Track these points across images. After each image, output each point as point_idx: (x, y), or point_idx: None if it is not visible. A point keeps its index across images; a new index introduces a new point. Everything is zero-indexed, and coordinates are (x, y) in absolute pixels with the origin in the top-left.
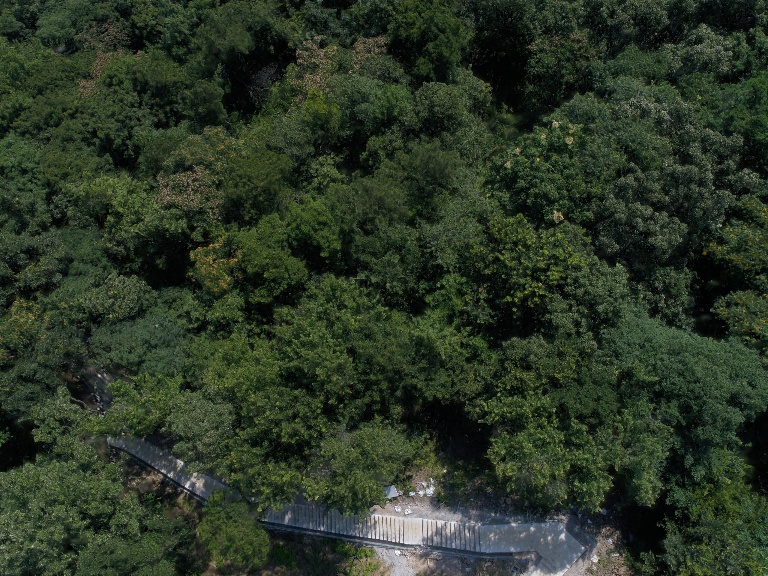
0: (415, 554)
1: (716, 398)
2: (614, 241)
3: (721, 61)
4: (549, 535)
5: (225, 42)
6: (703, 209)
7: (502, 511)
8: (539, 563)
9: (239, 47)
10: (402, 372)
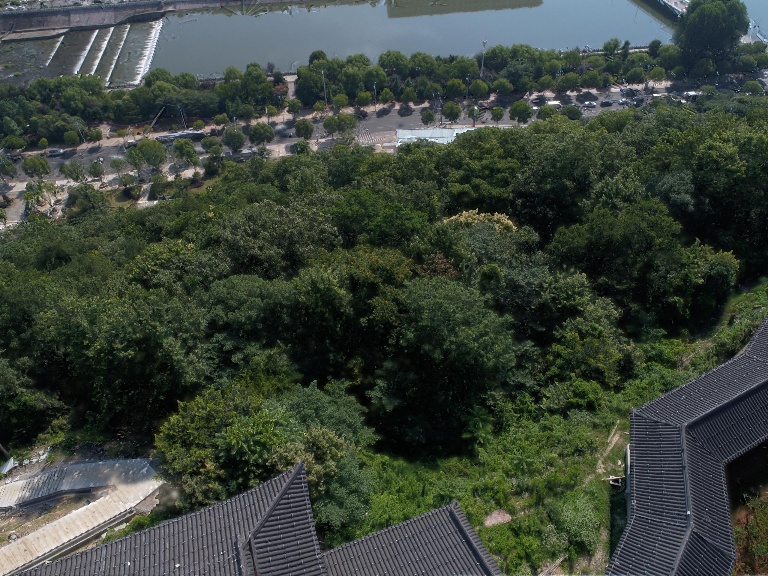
0: (3, 517)
1: None
2: None
3: None
4: (131, 469)
5: (52, 243)
6: None
7: (97, 456)
8: (111, 492)
9: (62, 249)
10: (32, 322)
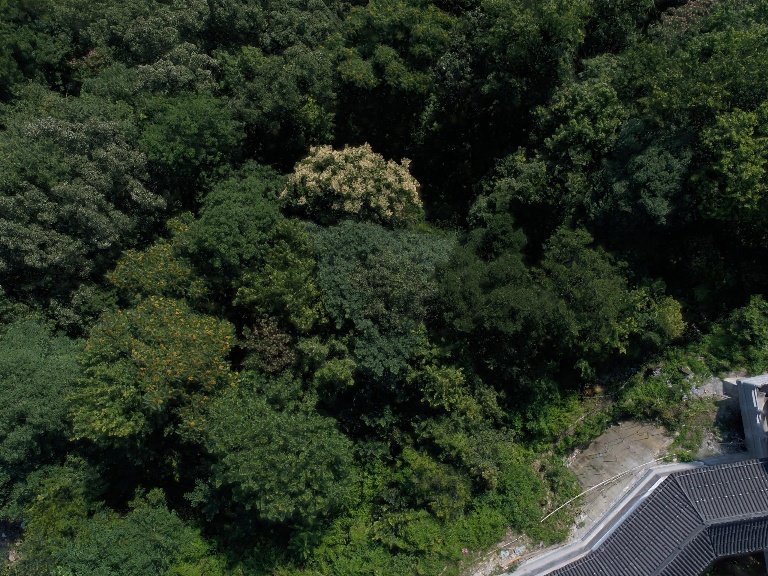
0: None
1: (2, 417)
2: (4, 259)
3: (181, 80)
4: None
5: None
6: (118, 227)
7: None
8: None
9: None
10: None
